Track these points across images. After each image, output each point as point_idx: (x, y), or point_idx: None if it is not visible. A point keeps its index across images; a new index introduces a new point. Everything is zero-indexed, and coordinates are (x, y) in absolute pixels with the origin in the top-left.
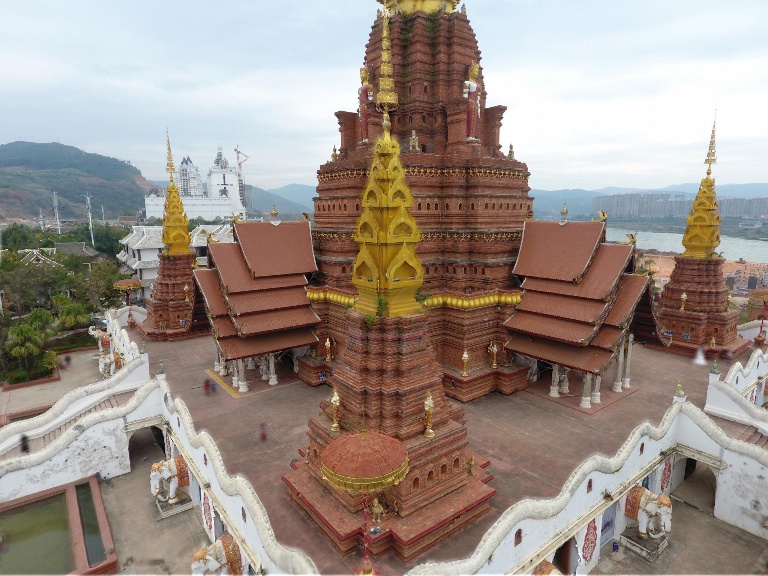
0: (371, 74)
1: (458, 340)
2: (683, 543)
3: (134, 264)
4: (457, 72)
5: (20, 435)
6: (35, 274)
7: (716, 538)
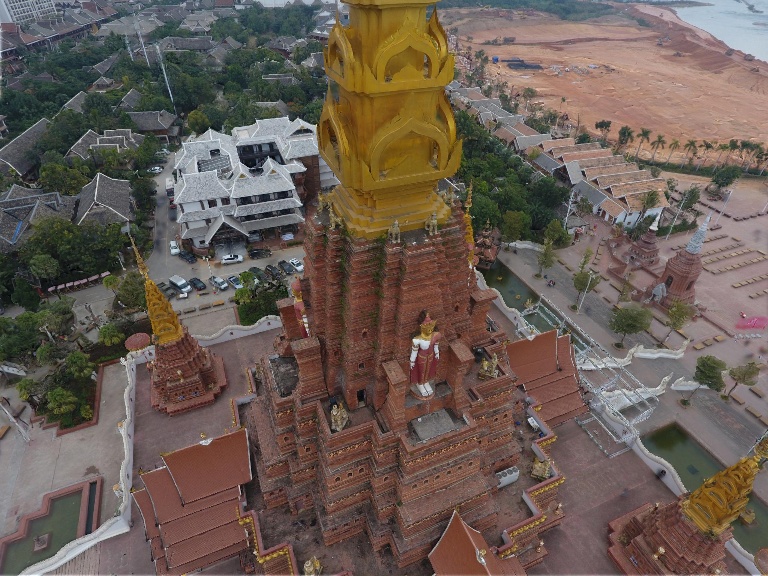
0: (305, 291)
1: None
2: None
3: (178, 216)
4: (405, 325)
5: (39, 572)
6: (92, 237)
7: None
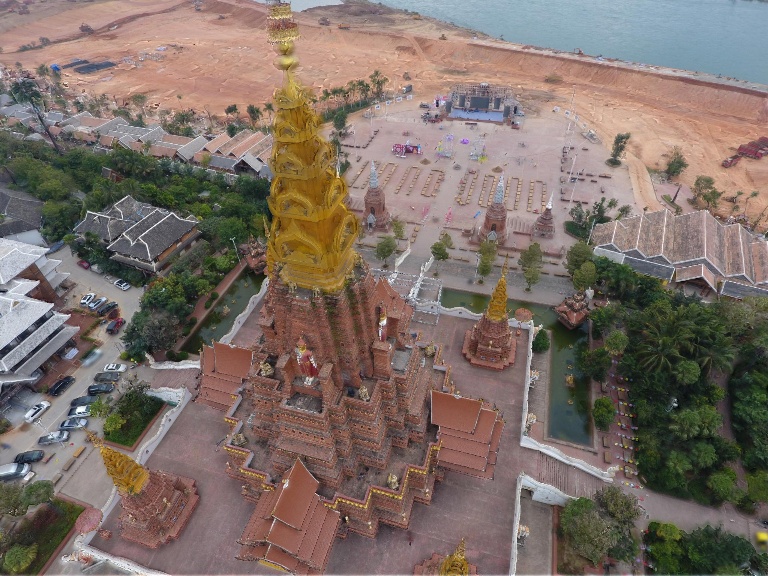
0: None
1: (420, 482)
2: (528, 526)
3: None
4: None
5: None
6: None
7: (536, 515)
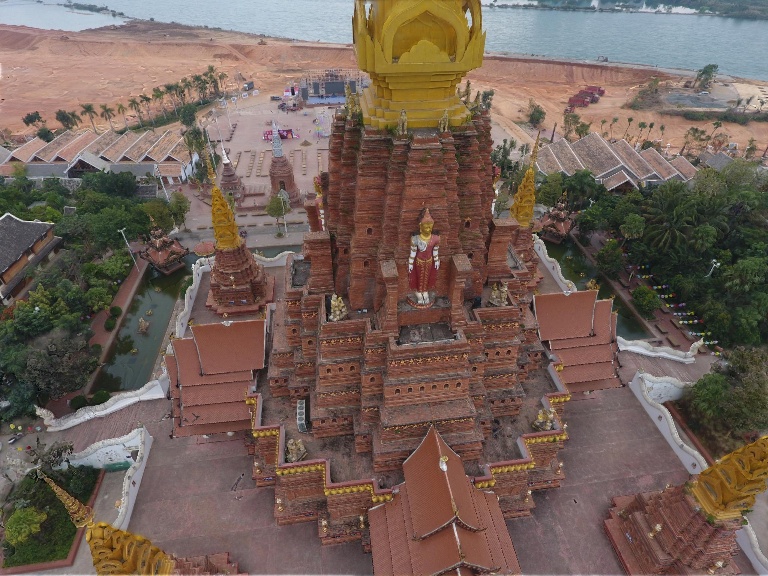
0: None
1: None
2: None
3: None
4: None
5: None
6: None
7: None
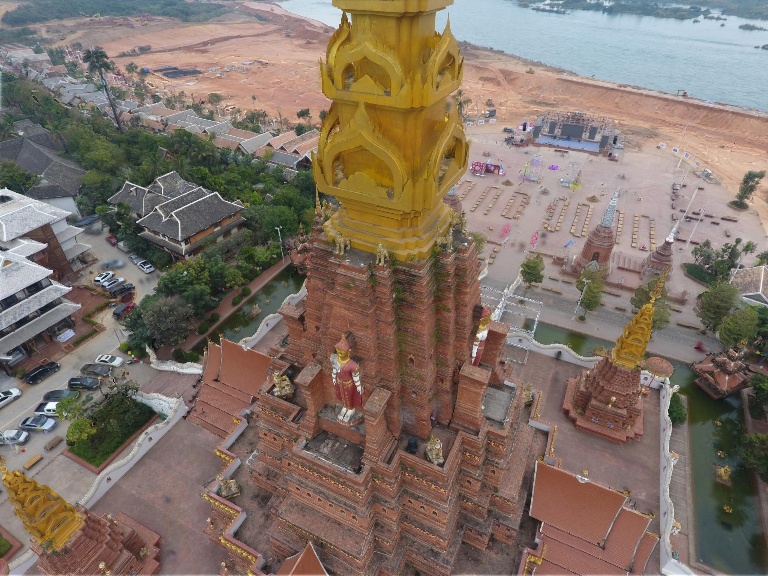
0: (352, 347)
1: None
2: None
3: None
4: (468, 326)
5: None
6: None
7: None
